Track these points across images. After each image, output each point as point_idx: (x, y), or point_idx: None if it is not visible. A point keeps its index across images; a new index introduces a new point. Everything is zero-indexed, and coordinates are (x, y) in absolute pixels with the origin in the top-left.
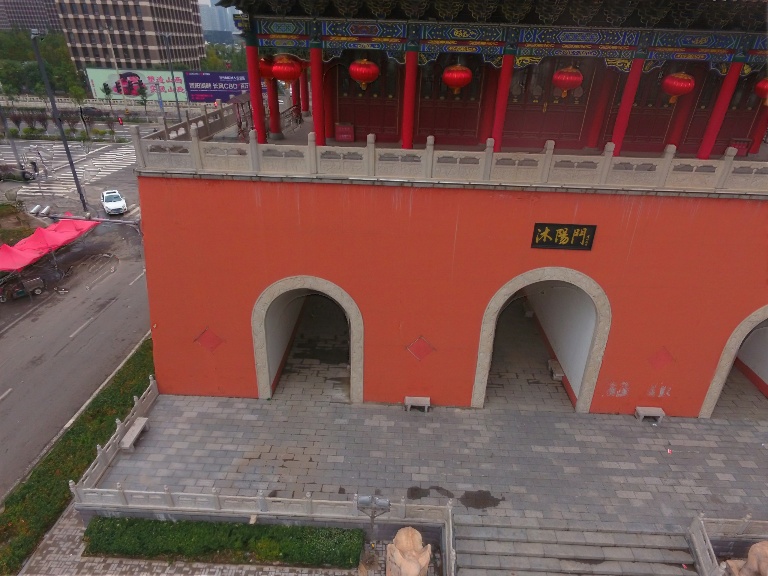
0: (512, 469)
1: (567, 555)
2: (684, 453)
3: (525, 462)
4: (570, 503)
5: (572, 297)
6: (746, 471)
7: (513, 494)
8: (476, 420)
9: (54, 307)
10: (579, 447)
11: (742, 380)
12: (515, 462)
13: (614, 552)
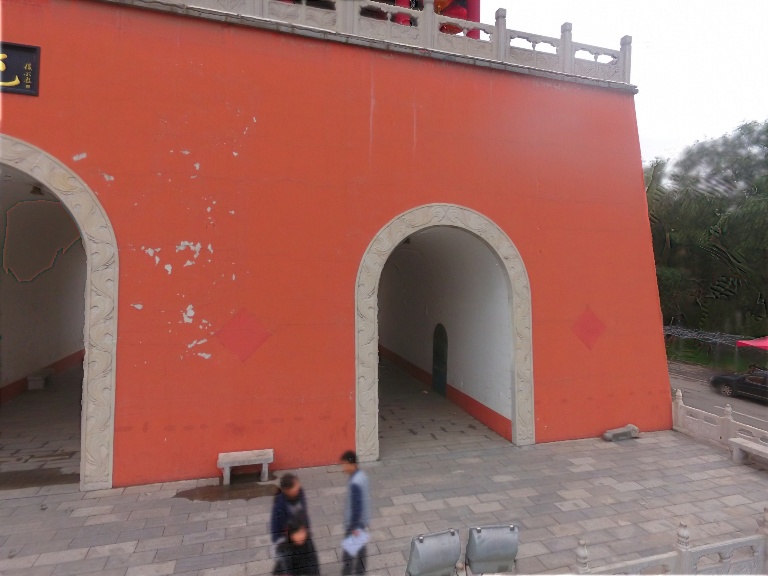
0: None
1: None
2: None
3: None
4: None
5: (84, 272)
6: None
7: None
8: None
9: (698, 384)
10: None
11: None
12: None
13: None
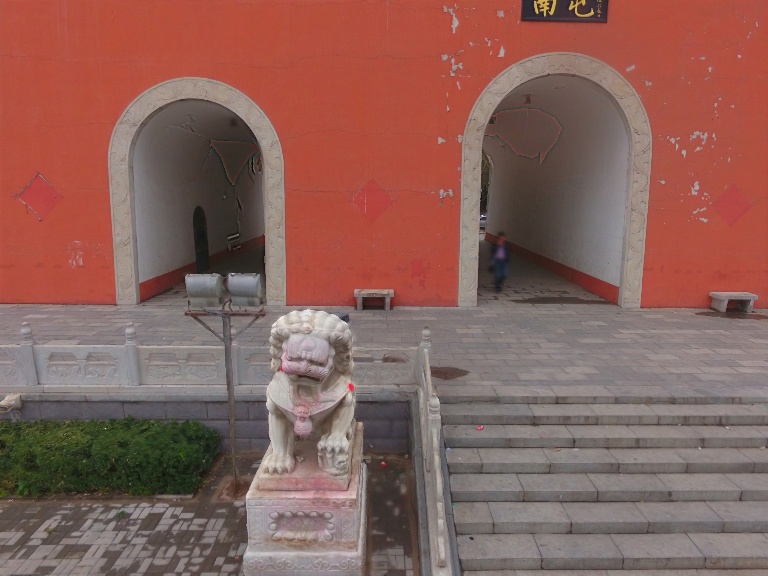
0: None
1: None
2: None
3: None
4: None
5: None
6: None
7: None
8: None
9: None
10: None
11: None
12: None
13: None
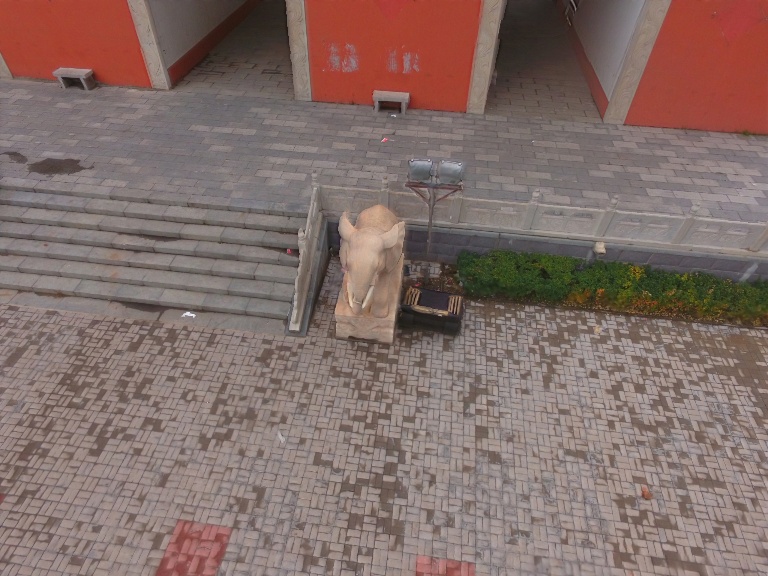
0: (137, 143)
1: (127, 228)
2: (404, 142)
3: (164, 138)
4: (178, 176)
5: None
6: (475, 163)
7: (109, 164)
8: (145, 99)
9: None
10: (258, 129)
11: (576, 83)
12: (149, 137)
13: (197, 229)
